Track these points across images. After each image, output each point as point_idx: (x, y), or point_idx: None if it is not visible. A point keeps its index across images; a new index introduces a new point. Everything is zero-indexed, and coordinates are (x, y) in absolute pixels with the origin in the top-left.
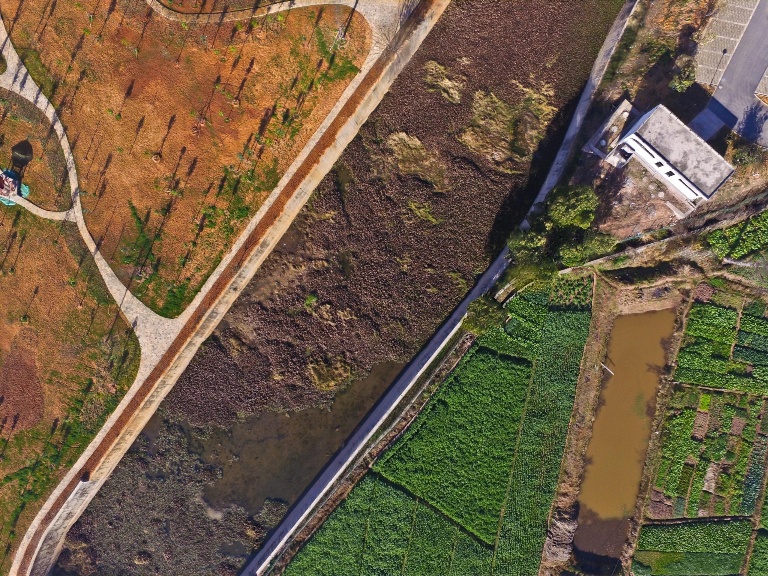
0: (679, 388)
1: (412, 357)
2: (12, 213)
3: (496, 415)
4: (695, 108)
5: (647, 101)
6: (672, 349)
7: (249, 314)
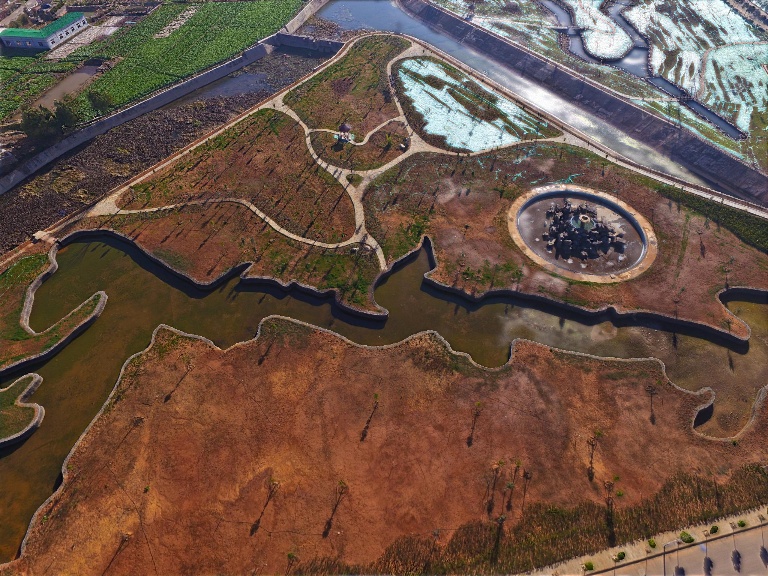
0: None
1: None
2: None
3: None
4: None
5: None
6: None
7: None
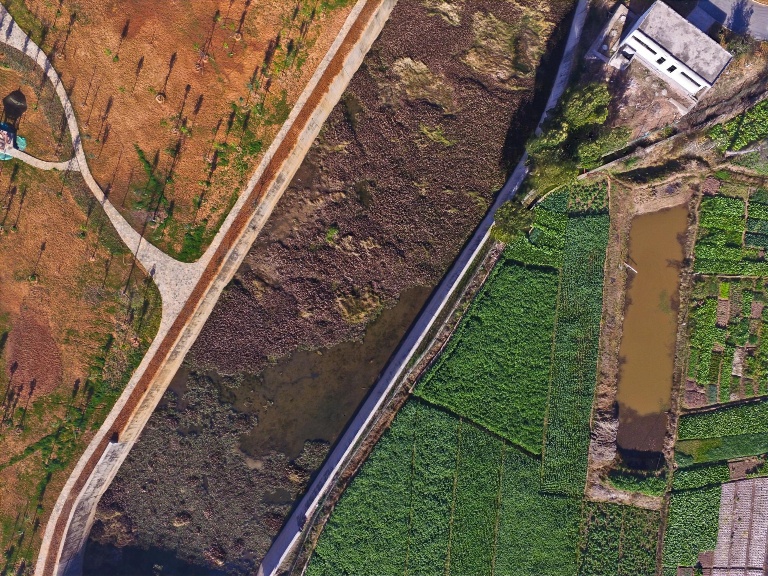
0: (699, 279)
1: (439, 280)
2: (9, 168)
3: (529, 325)
4: (687, 7)
5: (642, 4)
6: (688, 242)
7: (270, 254)
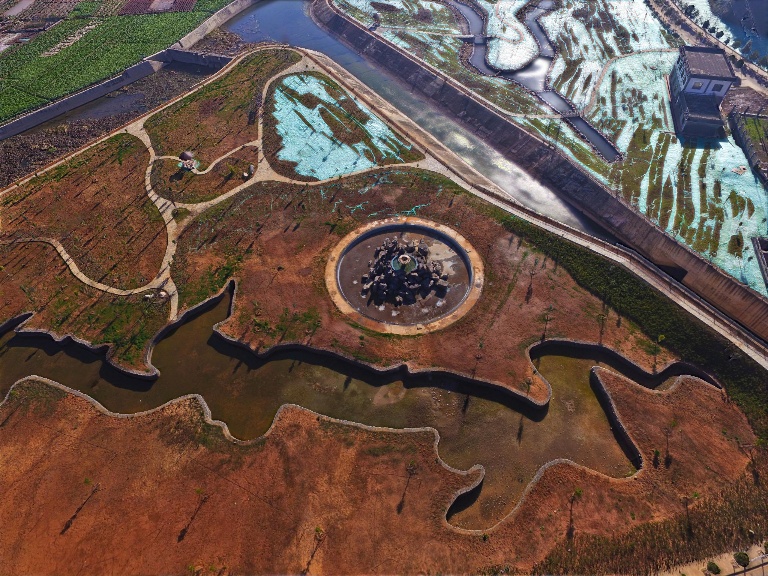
0: None
1: None
2: None
3: None
4: None
5: None
6: None
7: None
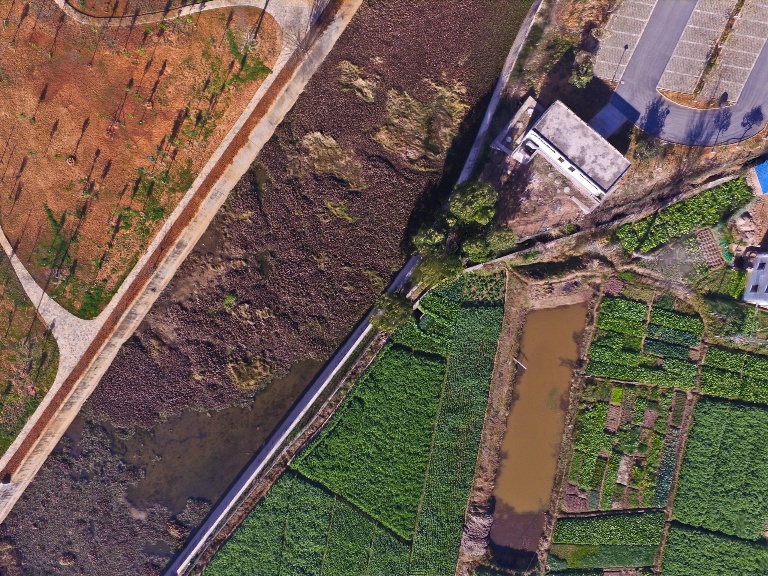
0: (591, 382)
1: (331, 355)
2: None
3: (411, 411)
4: (598, 103)
5: (551, 97)
6: (584, 343)
7: (169, 314)
